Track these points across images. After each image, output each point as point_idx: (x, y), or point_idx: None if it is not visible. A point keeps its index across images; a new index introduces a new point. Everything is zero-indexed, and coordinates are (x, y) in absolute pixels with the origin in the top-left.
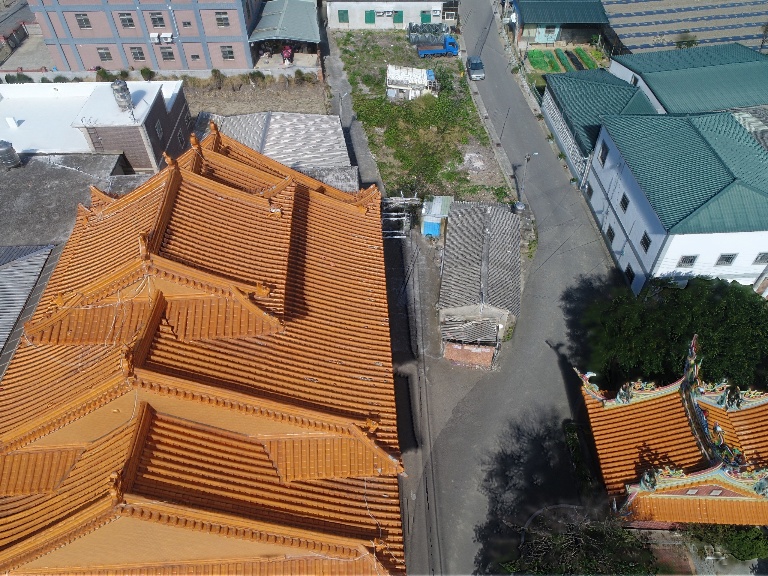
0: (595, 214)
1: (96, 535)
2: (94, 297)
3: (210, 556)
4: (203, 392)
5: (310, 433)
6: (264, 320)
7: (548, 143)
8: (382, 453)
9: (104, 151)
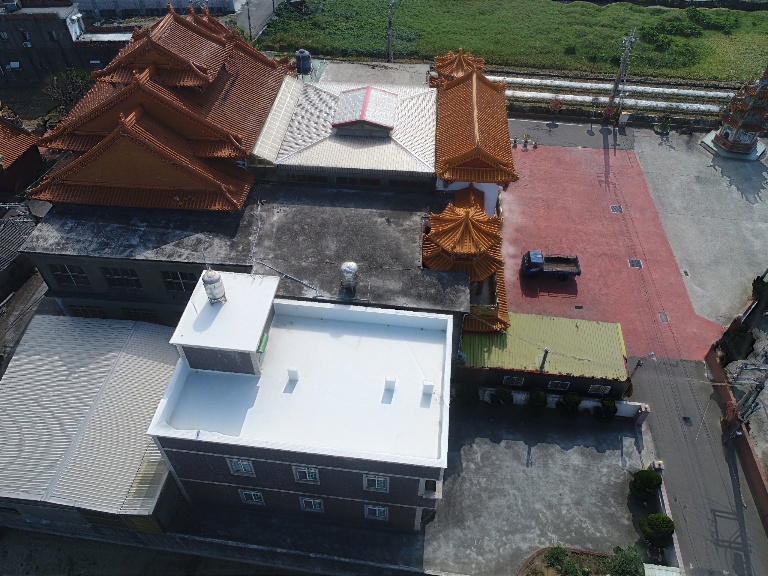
0: None
1: None
2: None
3: None
4: None
5: None
6: None
7: None
8: None
9: None
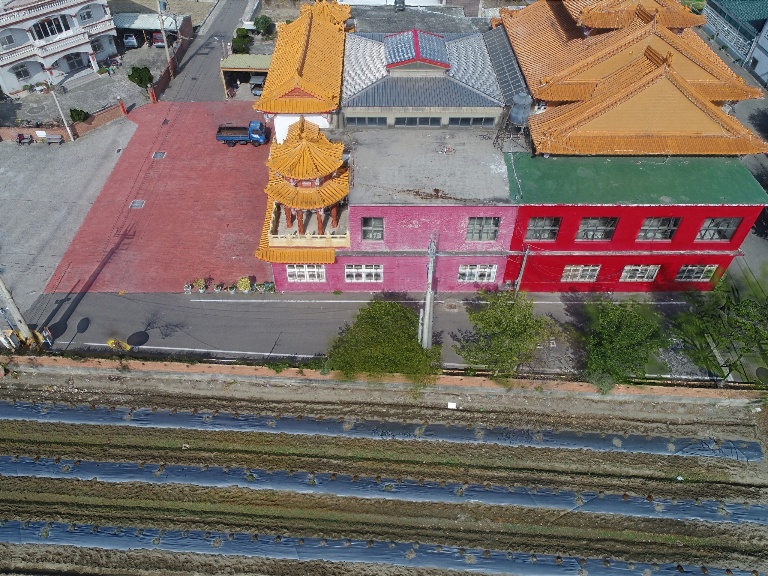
0: (760, 77)
1: (636, 98)
2: (608, 5)
3: (669, 129)
4: (678, 42)
5: (711, 80)
6: (694, 19)
7: (709, 42)
8: (751, 88)
9: (451, 6)
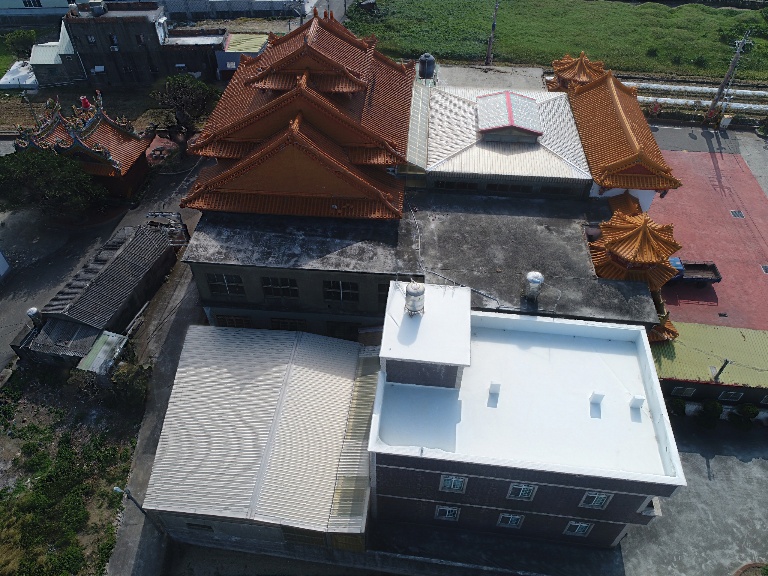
0: None
1: None
2: None
3: None
4: None
5: None
6: None
7: None
8: None
9: None
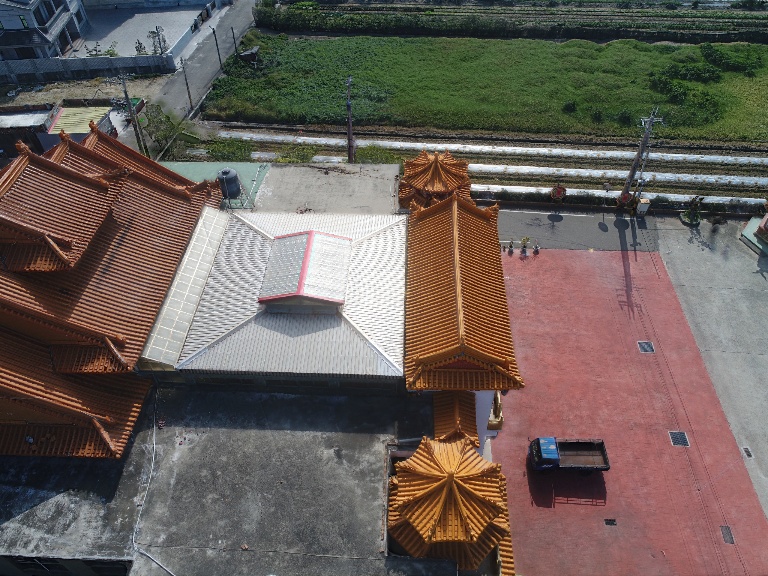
0: None
1: None
2: None
3: None
4: None
5: None
6: None
7: None
8: None
9: None
